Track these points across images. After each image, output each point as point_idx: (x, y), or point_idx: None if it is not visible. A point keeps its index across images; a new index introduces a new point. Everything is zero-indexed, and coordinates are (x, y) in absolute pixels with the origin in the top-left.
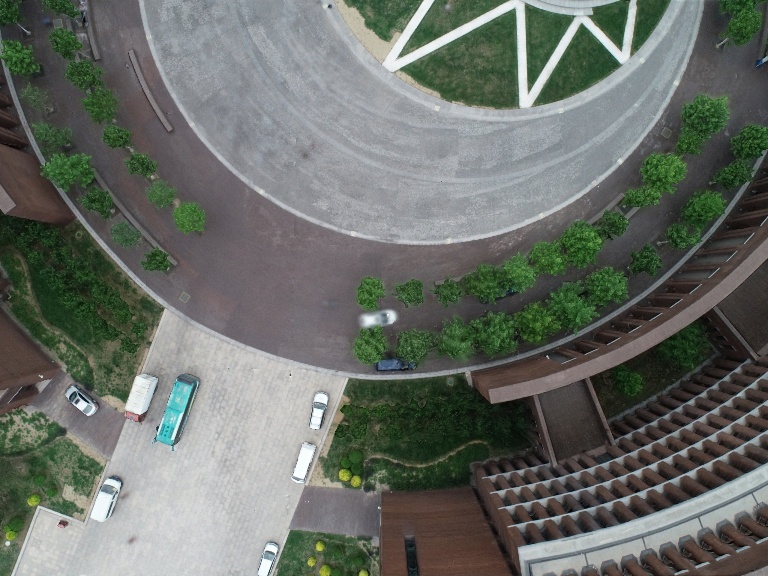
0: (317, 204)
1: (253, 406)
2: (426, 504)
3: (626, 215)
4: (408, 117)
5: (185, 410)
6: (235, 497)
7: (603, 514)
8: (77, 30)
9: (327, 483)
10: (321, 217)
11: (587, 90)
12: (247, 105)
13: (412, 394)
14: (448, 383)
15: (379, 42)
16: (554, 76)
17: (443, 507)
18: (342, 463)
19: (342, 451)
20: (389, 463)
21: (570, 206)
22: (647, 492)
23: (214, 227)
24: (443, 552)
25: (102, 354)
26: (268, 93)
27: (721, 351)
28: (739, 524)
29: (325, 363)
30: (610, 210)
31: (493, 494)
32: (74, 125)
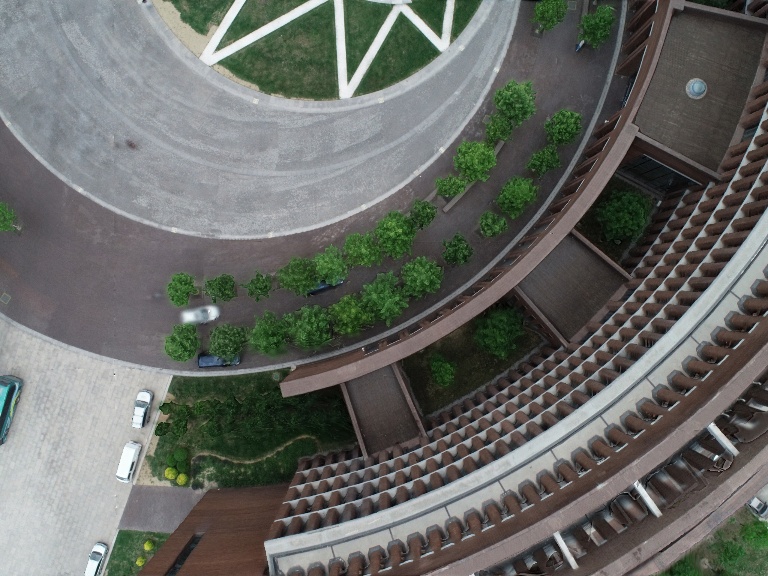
0: (137, 201)
1: (78, 406)
2: (243, 500)
3: (448, 204)
4: (227, 111)
5: (2, 412)
6: (63, 498)
7: (363, 506)
8: None
9: (155, 482)
10: (141, 214)
11: (407, 79)
12: (63, 103)
13: (238, 390)
14: (274, 378)
15: (195, 36)
16: (374, 66)
17: (256, 503)
18: (167, 461)
19: (169, 449)
20: (216, 460)
21: (392, 197)
22: (413, 482)
23: (33, 227)
24: (219, 548)
25: None
26: (84, 90)
27: (547, 339)
28: (485, 512)
29: (149, 361)
30: (432, 200)
31: (291, 489)
32: None
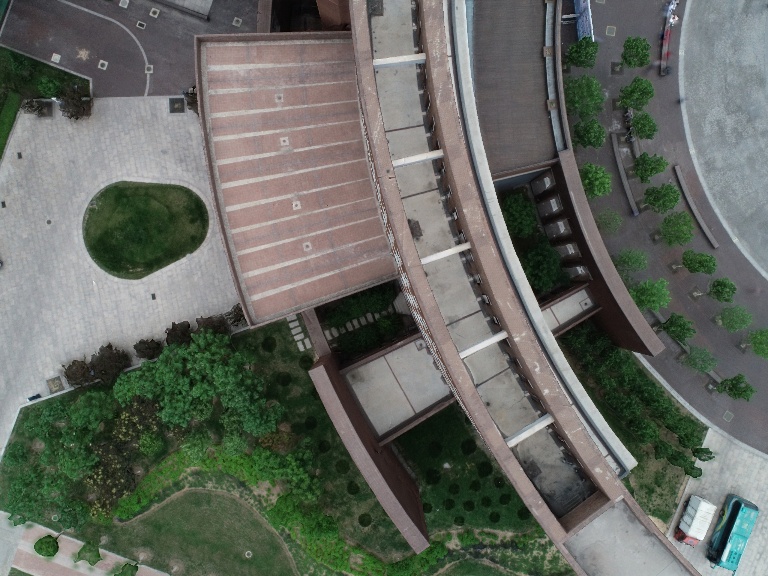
0: None
1: None
2: None
3: None
4: None
5: None
6: None
7: None
8: (620, 145)
9: None
10: None
11: None
12: None
13: None
14: None
15: None
16: None
17: None
18: None
19: None
20: None
21: None
22: None
23: None
24: None
25: (644, 474)
26: None
27: None
28: None
29: None
30: None
31: None
32: (617, 242)
